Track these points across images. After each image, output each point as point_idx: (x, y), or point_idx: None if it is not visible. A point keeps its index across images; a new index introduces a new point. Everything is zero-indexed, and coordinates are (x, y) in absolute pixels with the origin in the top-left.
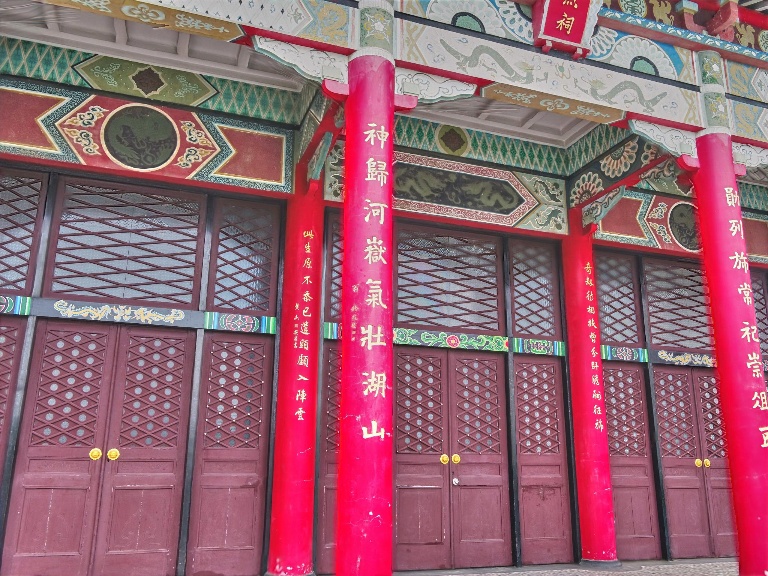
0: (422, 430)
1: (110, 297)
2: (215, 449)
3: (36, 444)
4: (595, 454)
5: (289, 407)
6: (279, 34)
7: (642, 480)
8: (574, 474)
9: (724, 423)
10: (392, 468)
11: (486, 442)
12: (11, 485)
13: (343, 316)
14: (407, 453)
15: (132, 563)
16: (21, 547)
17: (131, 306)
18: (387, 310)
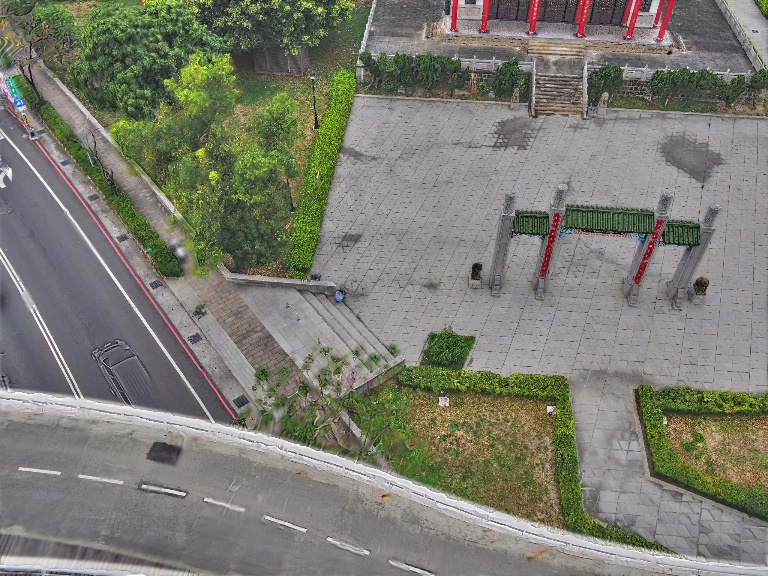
0: (552, 2)
1: None
2: (522, 4)
3: (501, 3)
4: (579, 8)
5: (532, 0)
6: None
7: (590, 11)
8: (576, 10)
9: (611, 2)
10: (546, 7)
11: (562, 4)
12: None
13: (533, 6)
14: (549, 5)
15: (511, 17)
16: (499, 14)
17: None
18: None
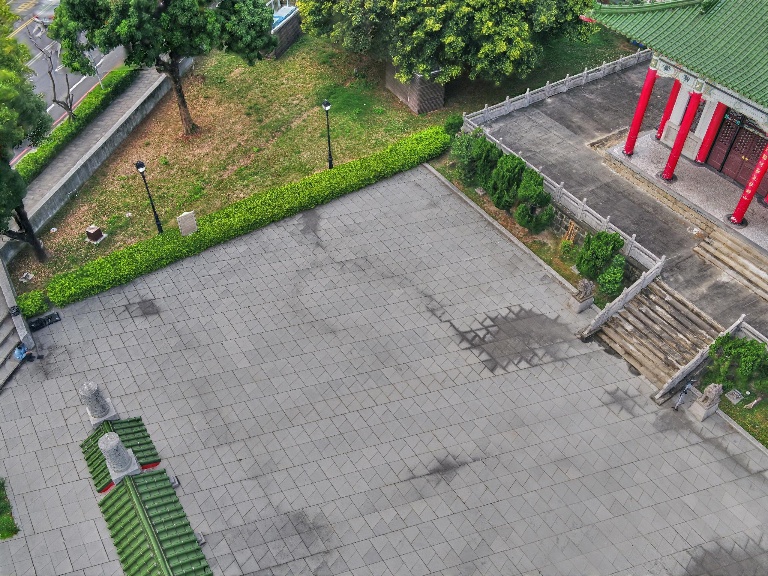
0: None
1: (756, 127)
2: None
3: (734, 150)
4: None
5: None
6: (759, 122)
7: None
8: None
9: None
10: None
11: None
12: (728, 156)
13: None
14: None
15: (743, 181)
16: None
17: (759, 131)
18: (756, 181)
